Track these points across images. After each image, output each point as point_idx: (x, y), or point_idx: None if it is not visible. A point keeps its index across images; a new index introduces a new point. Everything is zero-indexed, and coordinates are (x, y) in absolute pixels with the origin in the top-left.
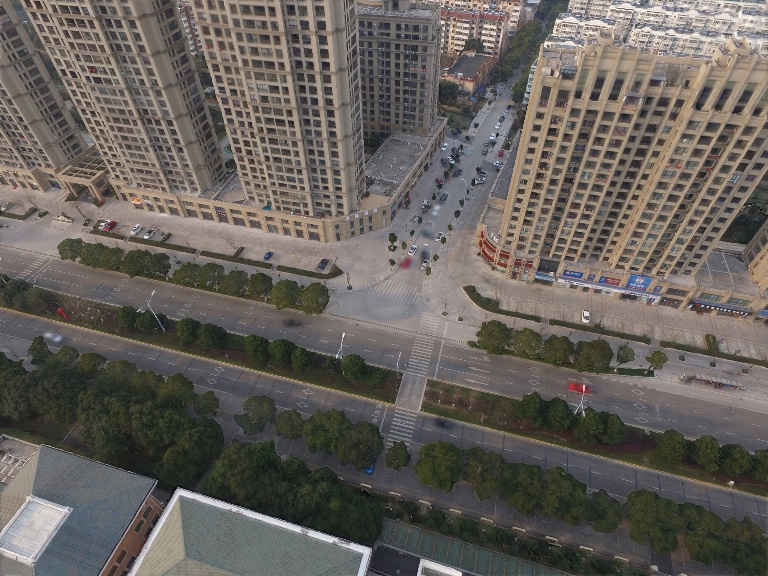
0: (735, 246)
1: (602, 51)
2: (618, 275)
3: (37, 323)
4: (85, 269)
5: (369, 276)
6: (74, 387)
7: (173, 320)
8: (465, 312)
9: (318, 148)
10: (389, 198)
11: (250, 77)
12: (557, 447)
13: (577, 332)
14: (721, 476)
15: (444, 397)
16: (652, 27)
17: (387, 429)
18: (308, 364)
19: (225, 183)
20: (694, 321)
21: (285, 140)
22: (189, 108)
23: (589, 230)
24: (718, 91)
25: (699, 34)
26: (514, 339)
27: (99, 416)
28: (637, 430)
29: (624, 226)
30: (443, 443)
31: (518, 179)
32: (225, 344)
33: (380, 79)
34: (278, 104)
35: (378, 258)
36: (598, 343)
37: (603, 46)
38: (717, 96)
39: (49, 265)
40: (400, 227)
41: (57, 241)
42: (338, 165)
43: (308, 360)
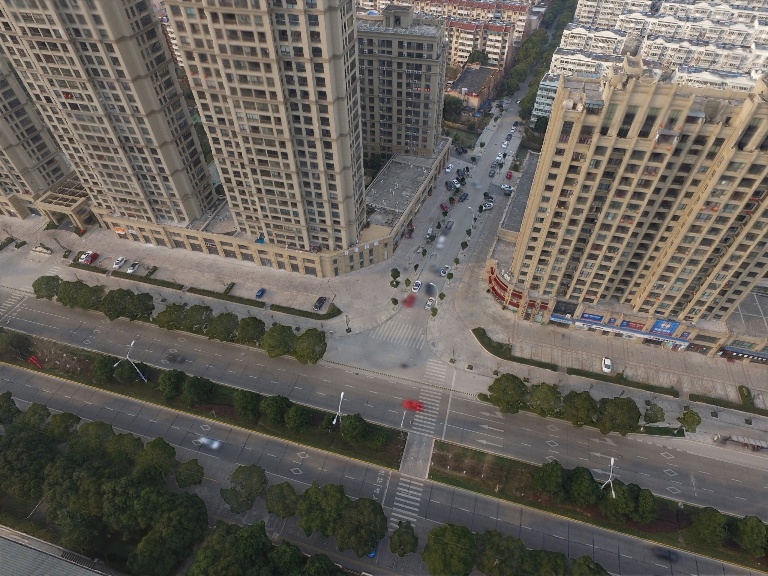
0: (764, 281)
1: (633, 85)
2: (642, 319)
3: (8, 372)
4: (63, 308)
5: (370, 316)
6: (41, 457)
7: (156, 368)
8: (475, 359)
9: (314, 180)
10: (391, 229)
11: (239, 106)
12: (581, 524)
13: (598, 383)
14: (767, 561)
15: (454, 462)
16: (665, 39)
17: (391, 501)
18: (303, 424)
19: (215, 212)
20: (725, 370)
21: (278, 172)
22: (175, 135)
23: (611, 272)
24: (764, 130)
25: (715, 47)
26: (530, 396)
27: (67, 494)
28: (669, 503)
29: (649, 268)
30: (455, 527)
31: (533, 217)
32: (212, 398)
33: (381, 99)
34: (270, 135)
35: (379, 295)
36: (624, 403)
37: (635, 79)
38: (763, 135)
39: (24, 303)
40: (403, 259)
41: (34, 275)
42: (336, 198)
43: (303, 420)
